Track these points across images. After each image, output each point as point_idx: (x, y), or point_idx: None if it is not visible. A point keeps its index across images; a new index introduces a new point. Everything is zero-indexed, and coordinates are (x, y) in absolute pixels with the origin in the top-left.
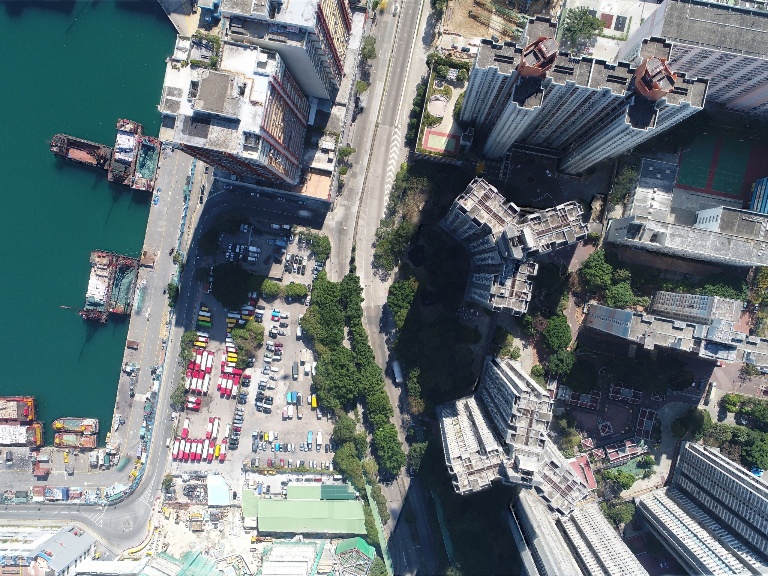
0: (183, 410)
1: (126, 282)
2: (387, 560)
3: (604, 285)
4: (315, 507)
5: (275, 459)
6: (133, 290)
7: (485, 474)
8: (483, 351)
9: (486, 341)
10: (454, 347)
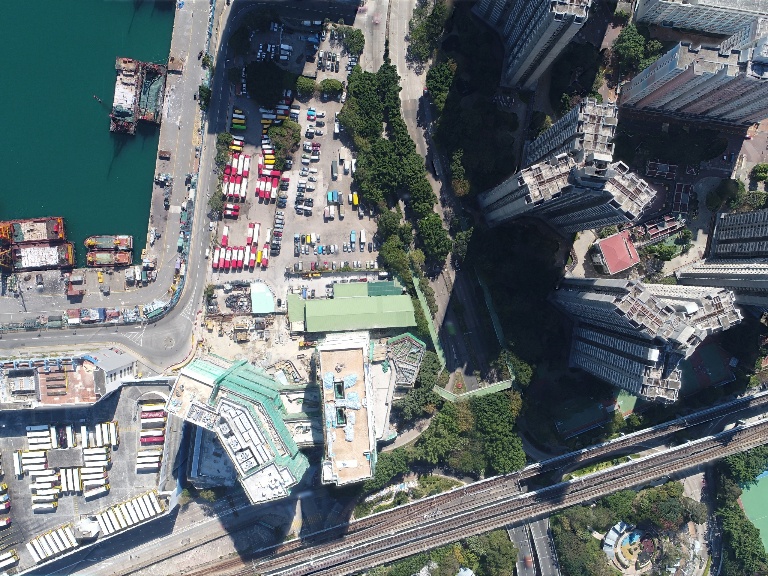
0: (221, 219)
1: (155, 88)
2: (439, 350)
3: (637, 60)
4: (363, 303)
5: (318, 262)
6: (161, 99)
7: (555, 183)
8: (521, 138)
9: (523, 128)
10: (494, 129)
